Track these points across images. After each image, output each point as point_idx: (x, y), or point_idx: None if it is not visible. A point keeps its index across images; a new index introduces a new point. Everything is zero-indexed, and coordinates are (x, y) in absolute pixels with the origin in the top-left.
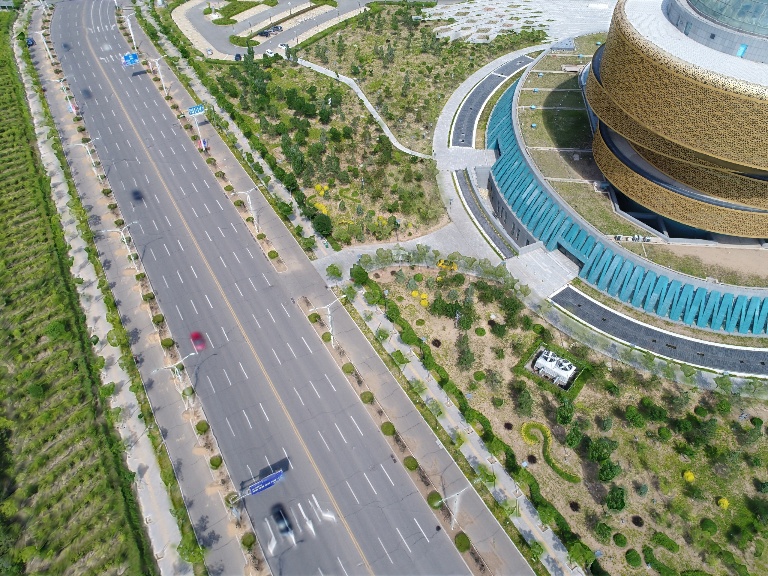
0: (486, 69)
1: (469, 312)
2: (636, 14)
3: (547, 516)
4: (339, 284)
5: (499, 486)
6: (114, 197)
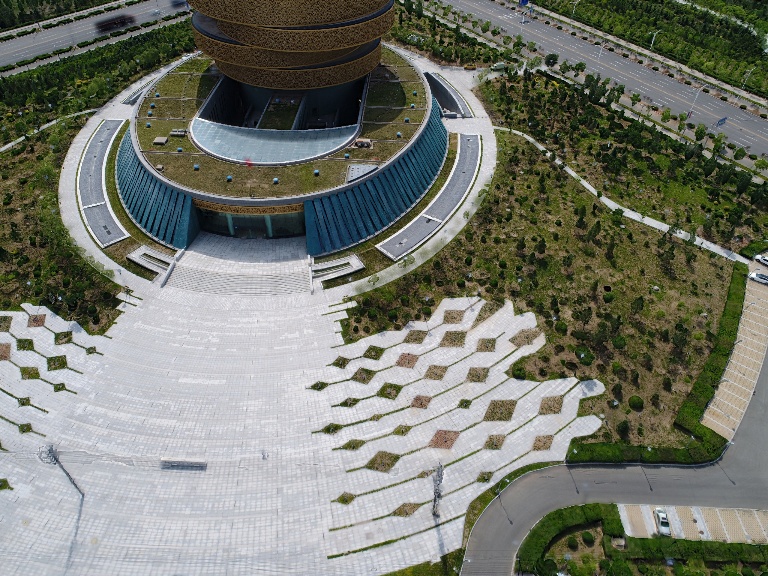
0: (449, 233)
1: (458, 38)
2: None
3: (429, 3)
4: None
5: (442, 20)
6: (714, 96)
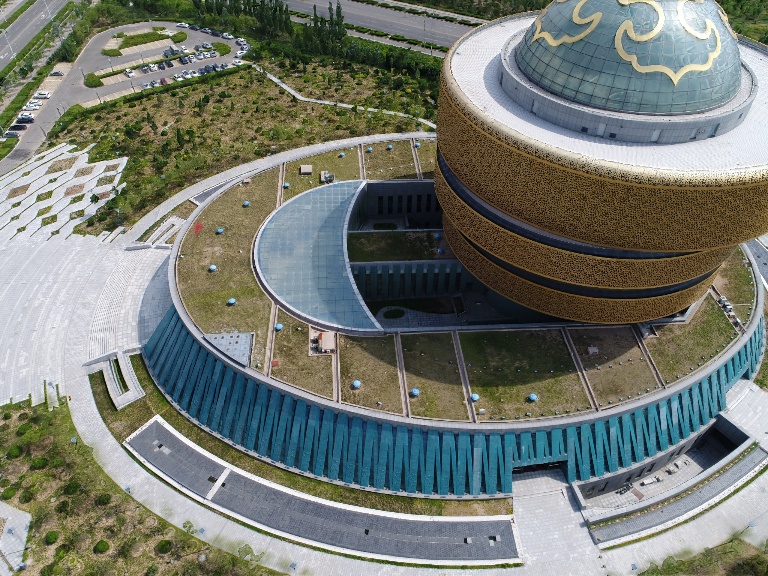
0: (181, 513)
1: None
2: (665, 167)
3: None
4: None
5: None
6: None
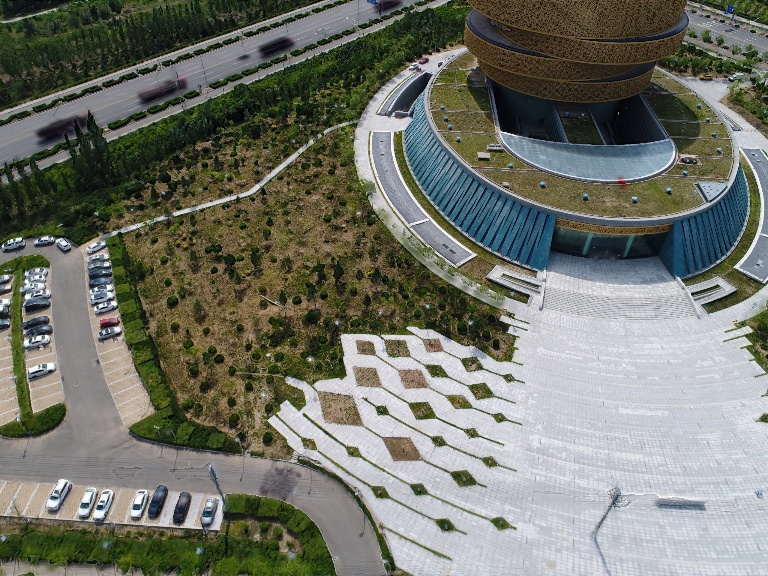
0: None
1: None
2: None
3: None
4: (761, 71)
5: None
6: None
